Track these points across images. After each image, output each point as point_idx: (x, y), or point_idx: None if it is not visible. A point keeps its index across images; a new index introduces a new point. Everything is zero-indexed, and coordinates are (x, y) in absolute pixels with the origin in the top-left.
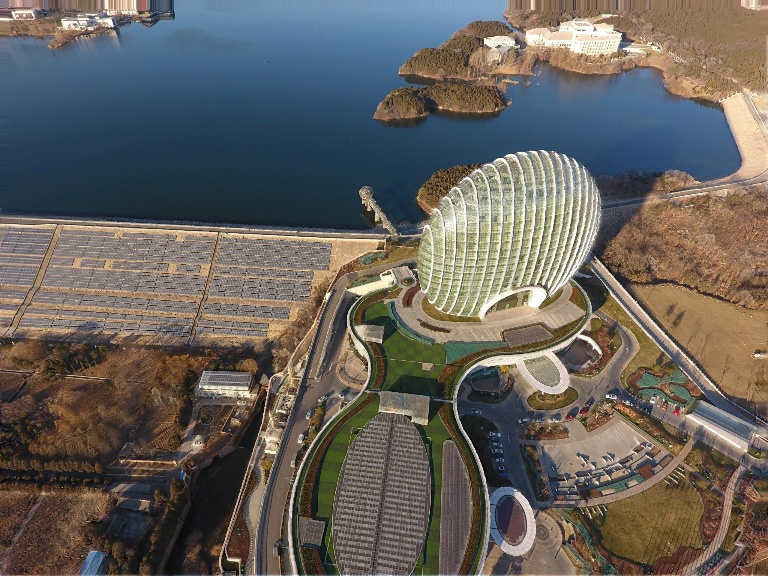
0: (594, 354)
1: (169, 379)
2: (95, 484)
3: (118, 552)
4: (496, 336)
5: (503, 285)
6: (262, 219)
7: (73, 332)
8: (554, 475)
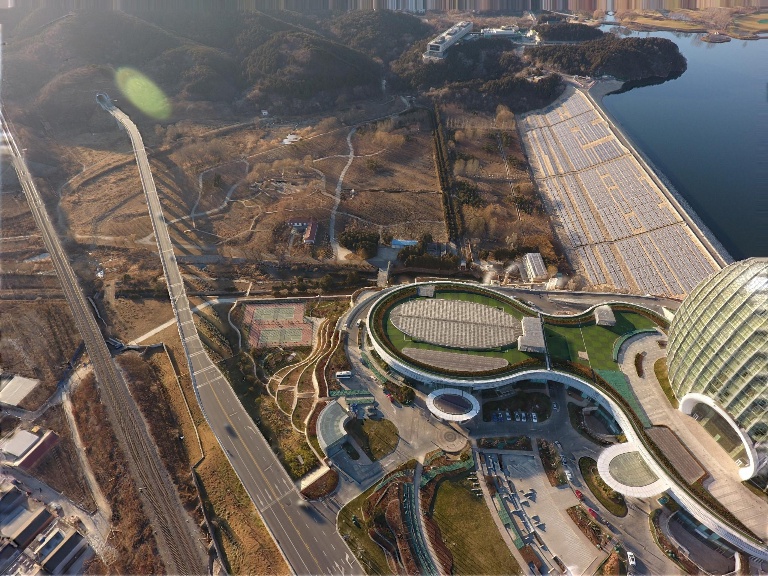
0: (713, 574)
1: (528, 242)
2: (452, 235)
3: (417, 246)
4: (657, 420)
5: (711, 386)
6: (736, 247)
7: (551, 200)
8: (505, 460)
